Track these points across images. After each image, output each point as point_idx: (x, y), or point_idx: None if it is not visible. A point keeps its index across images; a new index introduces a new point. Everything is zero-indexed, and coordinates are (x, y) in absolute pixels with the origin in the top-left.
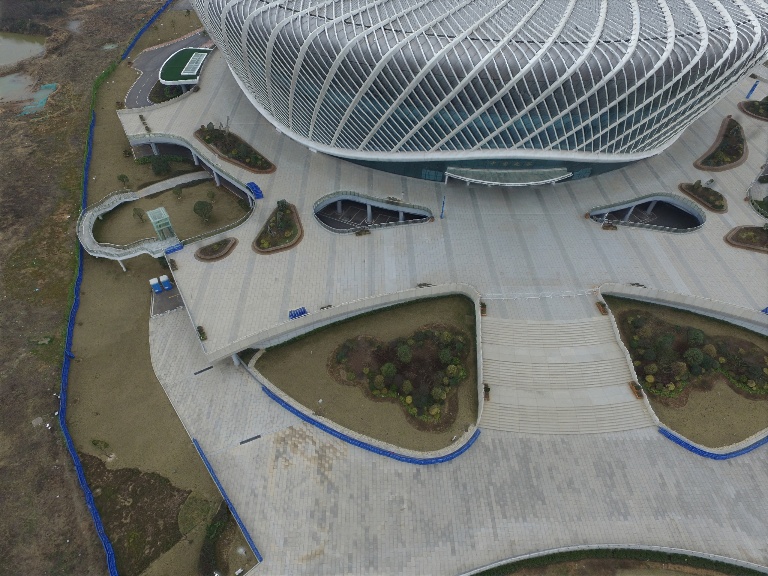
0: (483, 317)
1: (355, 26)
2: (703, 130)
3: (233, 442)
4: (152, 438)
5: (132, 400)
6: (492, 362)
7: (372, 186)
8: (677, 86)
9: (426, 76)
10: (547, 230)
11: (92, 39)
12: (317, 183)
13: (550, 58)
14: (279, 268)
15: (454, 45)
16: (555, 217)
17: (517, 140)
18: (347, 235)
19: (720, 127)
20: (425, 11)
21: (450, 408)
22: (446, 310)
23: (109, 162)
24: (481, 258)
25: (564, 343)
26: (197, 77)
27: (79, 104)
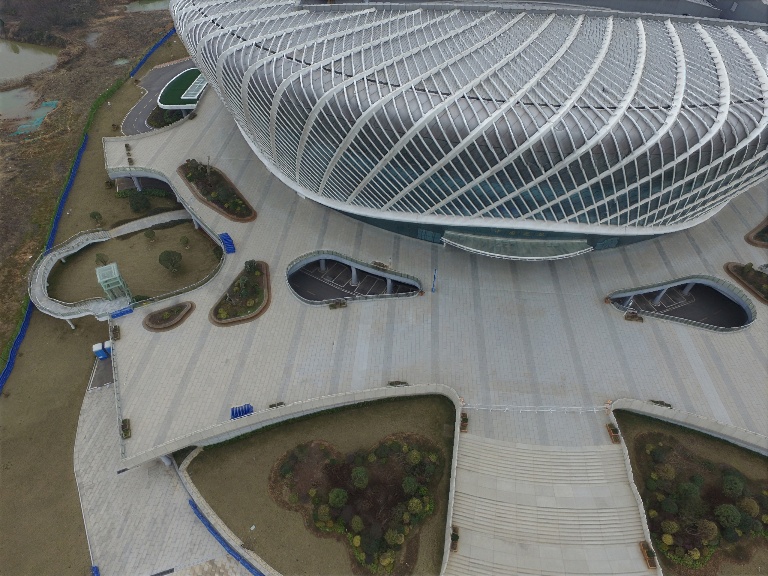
0: (463, 434)
1: (334, 75)
2: (759, 193)
3: (140, 575)
4: (49, 559)
5: (39, 503)
6: (467, 497)
7: (359, 244)
8: (729, 161)
9: (413, 138)
10: (556, 316)
11: (105, 53)
12: (298, 237)
13: (565, 126)
14: (233, 346)
15: (447, 105)
16: (568, 299)
17: (525, 211)
18: (319, 307)
19: None
20: (420, 59)
21: (407, 556)
22: (421, 415)
23: (89, 194)
24: (472, 349)
25: (560, 478)
26: (197, 102)
27: (75, 125)
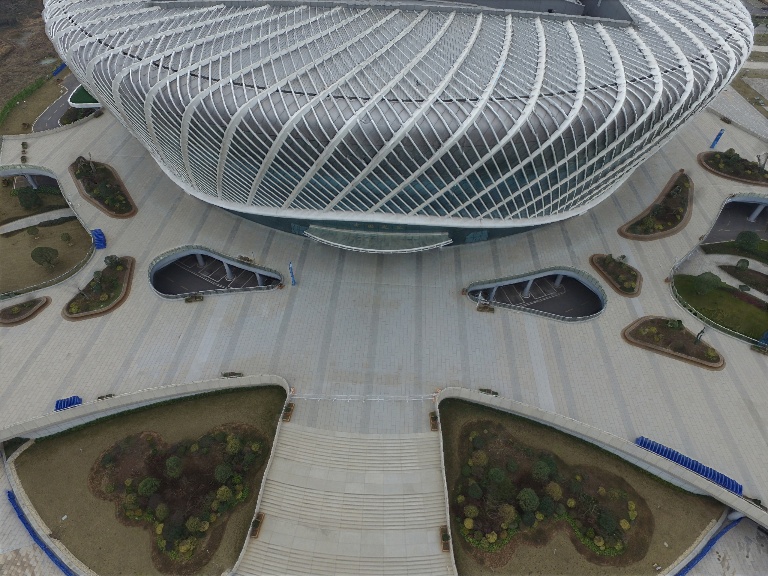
0: (285, 423)
1: (161, 70)
2: (645, 186)
3: None
4: None
5: None
6: (277, 485)
7: (232, 239)
8: (550, 153)
9: (236, 132)
10: (410, 308)
11: (33, 53)
12: (173, 233)
13: (371, 119)
14: (79, 339)
15: (261, 98)
16: (426, 291)
17: (371, 204)
18: (175, 301)
19: (667, 183)
20: (248, 54)
21: (210, 543)
22: (255, 406)
23: None
24: (317, 341)
25: (374, 465)
26: None
27: None
